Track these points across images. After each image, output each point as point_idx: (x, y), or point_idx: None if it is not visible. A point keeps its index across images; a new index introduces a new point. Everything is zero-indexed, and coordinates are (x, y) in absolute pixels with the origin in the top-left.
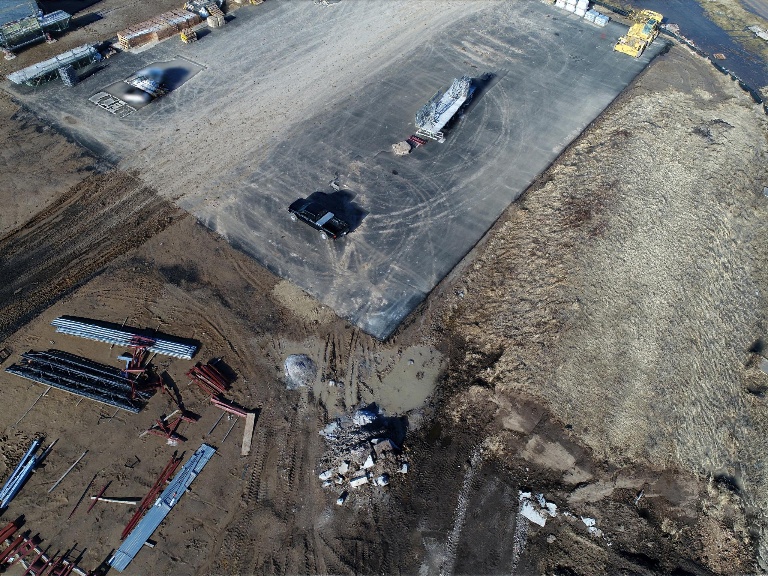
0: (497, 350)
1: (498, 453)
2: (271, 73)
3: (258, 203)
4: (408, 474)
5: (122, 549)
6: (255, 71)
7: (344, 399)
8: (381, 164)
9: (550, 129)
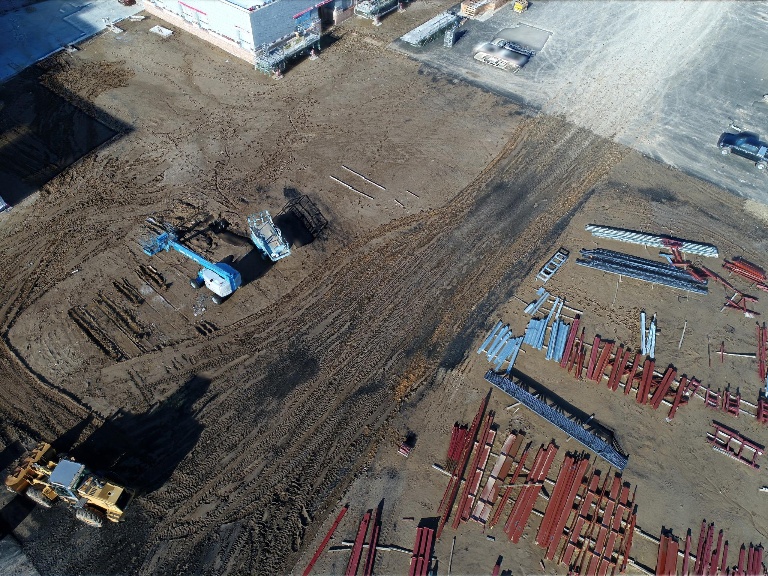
0: None
1: None
2: (612, 38)
3: (683, 141)
4: None
5: None
6: (597, 36)
7: None
8: (762, 111)
9: None
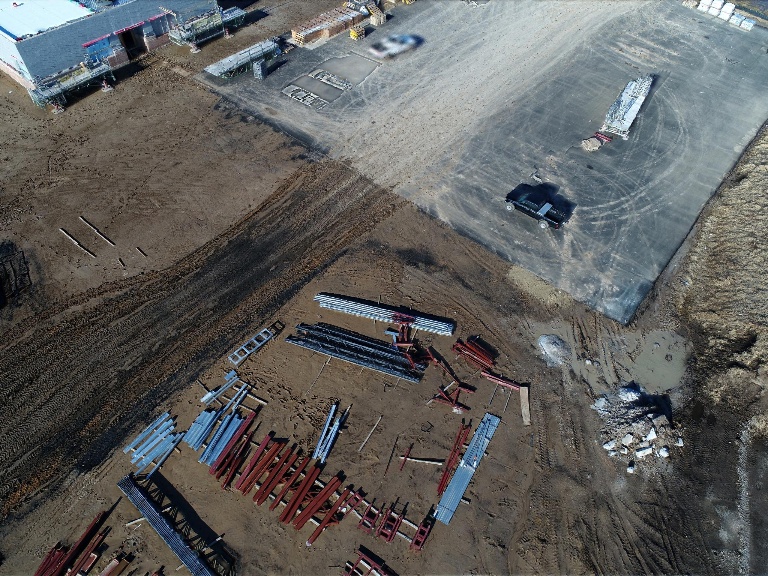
0: (745, 336)
1: (765, 431)
2: (444, 70)
3: (470, 193)
4: (684, 447)
5: (442, 504)
6: (429, 68)
7: (604, 377)
8: (574, 159)
9: (726, 129)
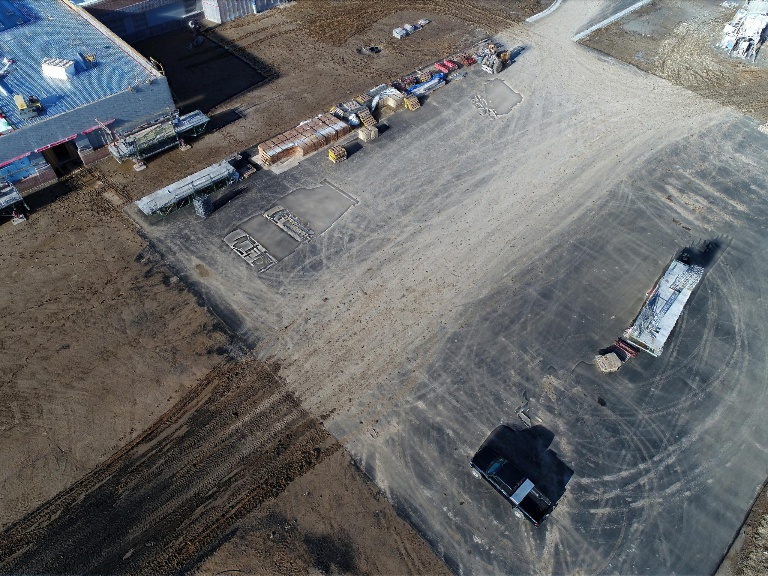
0: None
1: None
2: (434, 217)
3: (427, 437)
4: None
5: None
6: (415, 213)
7: None
8: (582, 385)
9: None
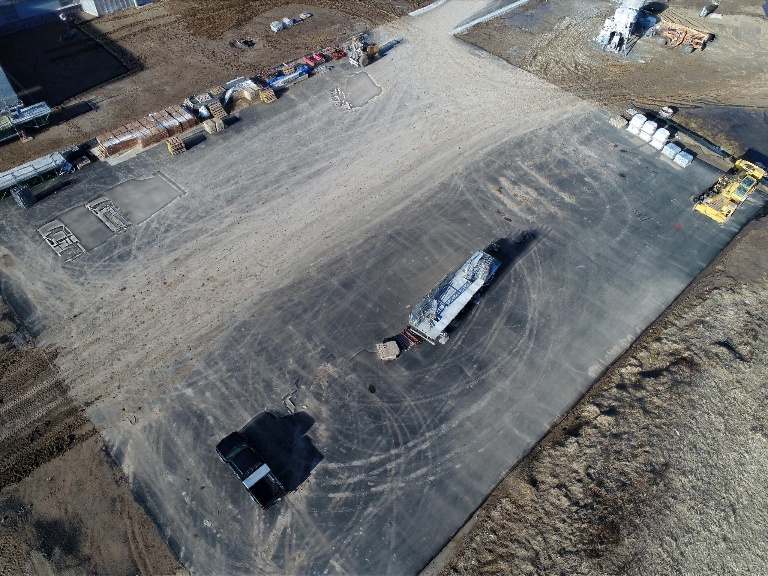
0: None
1: None
2: (257, 208)
3: (186, 424)
4: None
5: None
6: (239, 204)
7: None
8: (357, 372)
9: (590, 333)
